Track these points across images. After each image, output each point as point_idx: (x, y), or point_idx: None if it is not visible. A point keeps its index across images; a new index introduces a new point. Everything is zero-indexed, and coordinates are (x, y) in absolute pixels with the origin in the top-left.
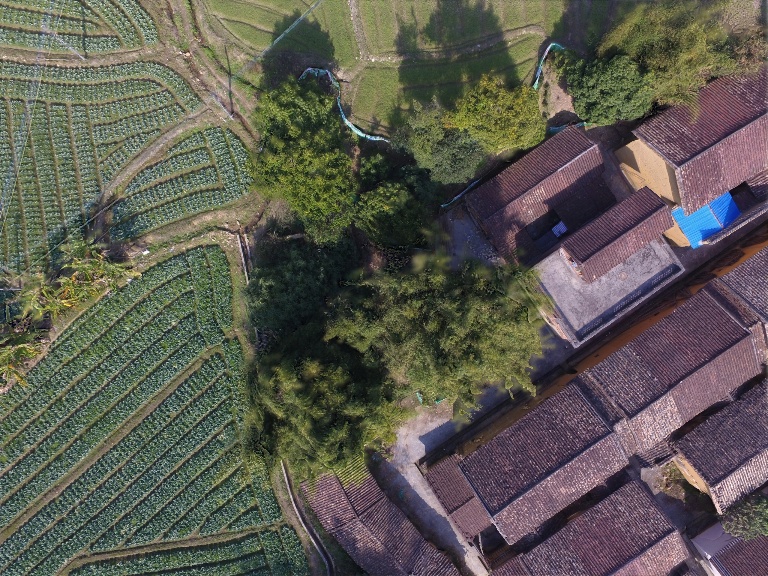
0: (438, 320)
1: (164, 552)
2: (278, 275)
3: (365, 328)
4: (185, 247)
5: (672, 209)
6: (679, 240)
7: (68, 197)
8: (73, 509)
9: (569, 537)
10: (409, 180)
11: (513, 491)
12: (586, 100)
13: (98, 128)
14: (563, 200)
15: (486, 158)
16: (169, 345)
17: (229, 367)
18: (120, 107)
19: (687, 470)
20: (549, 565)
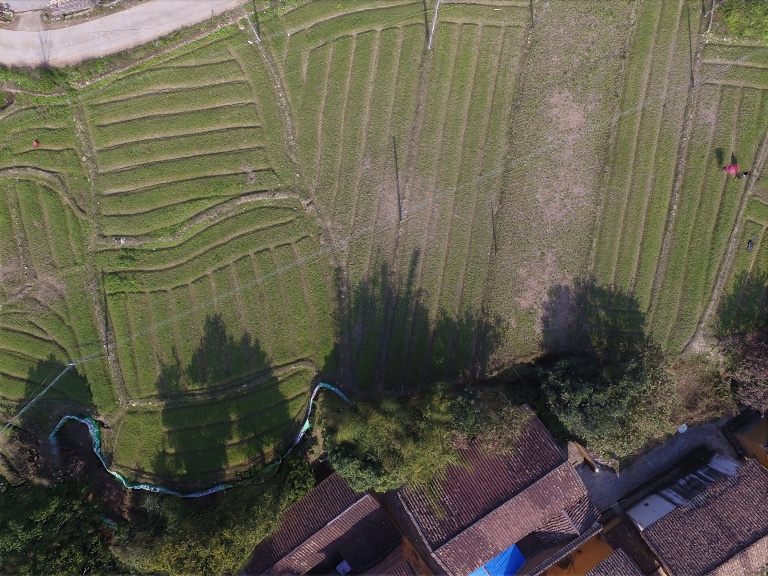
0: None
1: None
2: None
3: None
4: None
5: None
6: None
7: None
8: None
9: None
10: None
11: None
12: None
13: None
14: (341, 545)
15: None
16: None
17: None
18: None
19: None
20: None
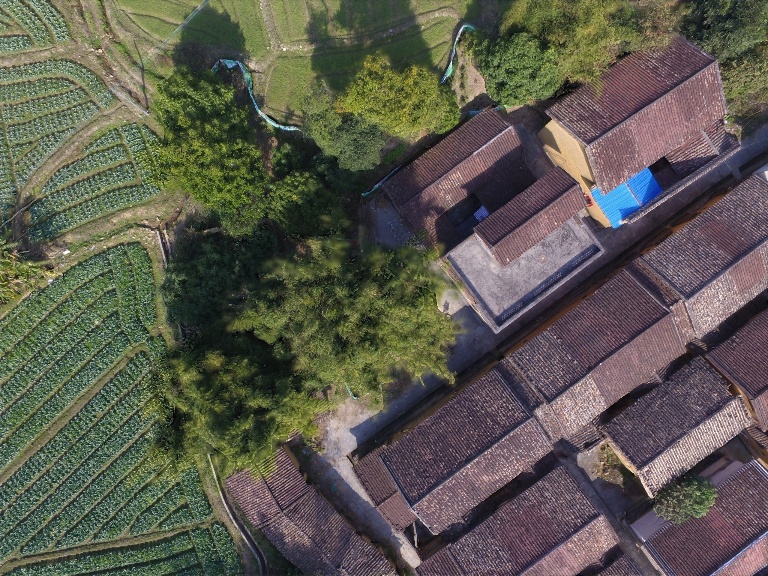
0: (337, 308)
1: (95, 553)
2: (193, 270)
3: (269, 319)
4: (106, 245)
5: None
6: (604, 221)
7: None
8: (2, 512)
9: (496, 525)
10: (320, 169)
11: (433, 480)
12: (494, 81)
13: (12, 128)
14: (482, 184)
15: (405, 145)
16: (93, 345)
17: (154, 365)
18: (33, 106)
19: (621, 454)
20: (476, 554)
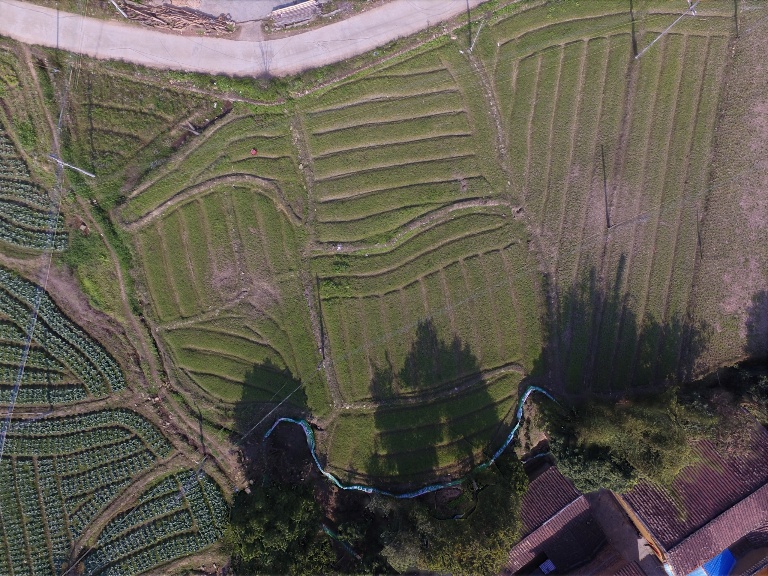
0: None
1: None
2: None
3: None
4: None
5: (663, 563)
6: None
7: (37, 555)
8: None
9: None
10: None
11: None
12: None
13: (66, 482)
14: (550, 544)
15: None
16: None
17: None
18: (88, 459)
19: None
20: None
